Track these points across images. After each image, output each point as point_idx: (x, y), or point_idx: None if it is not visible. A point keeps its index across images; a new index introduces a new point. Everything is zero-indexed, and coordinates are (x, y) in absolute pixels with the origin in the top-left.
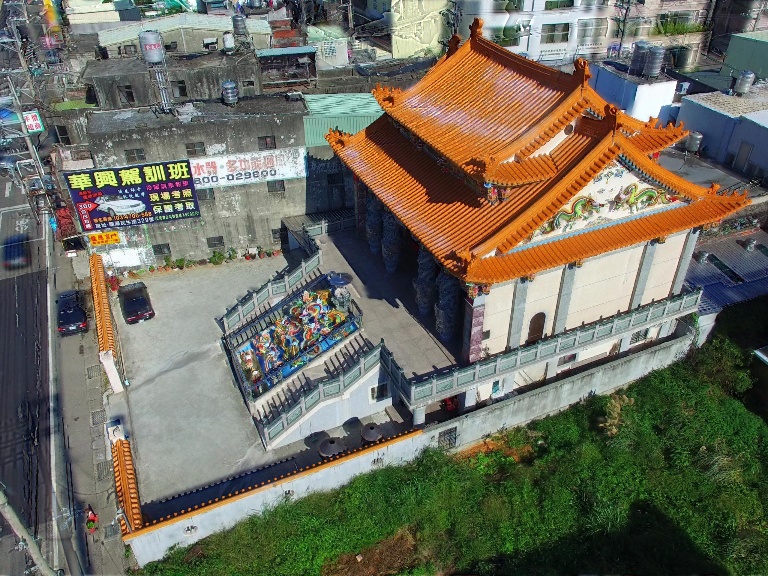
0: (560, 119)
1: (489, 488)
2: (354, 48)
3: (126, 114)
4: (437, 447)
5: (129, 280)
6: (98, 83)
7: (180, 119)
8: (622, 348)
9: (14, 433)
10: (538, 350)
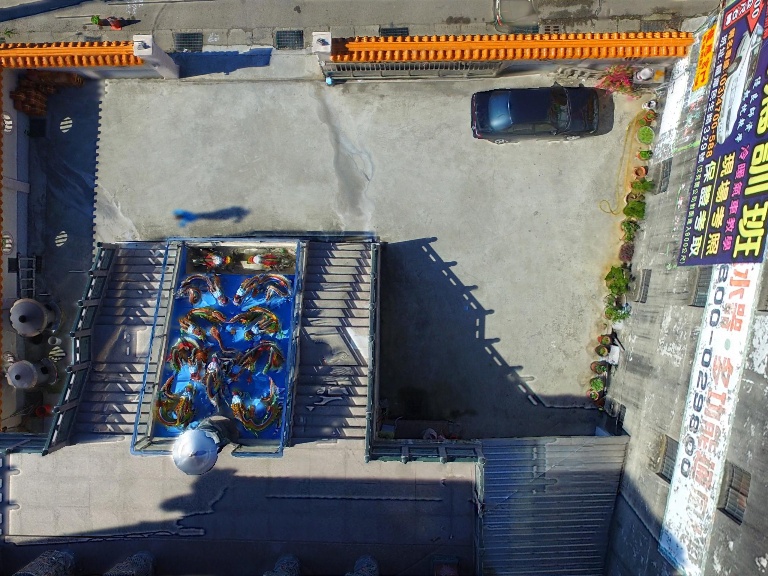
0: None
1: None
2: None
3: None
4: None
5: (633, 110)
6: None
7: None
8: None
9: None
10: None
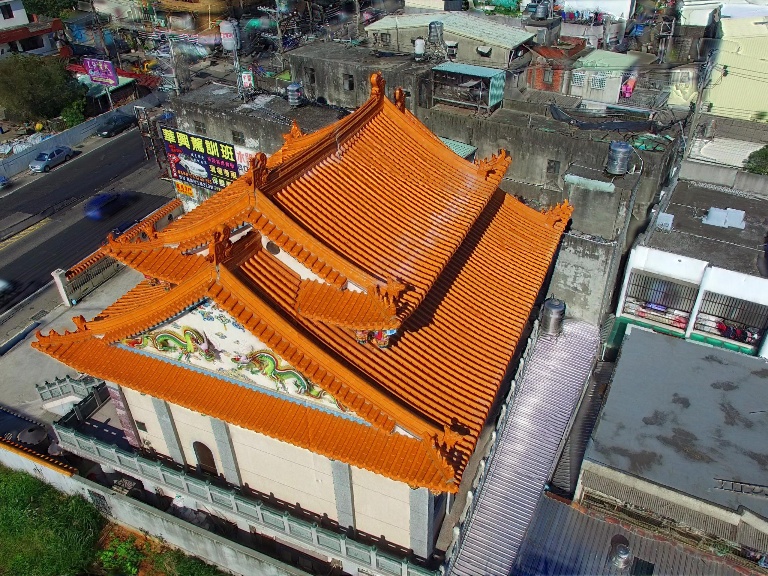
0: (225, 222)
1: (66, 572)
2: None
3: (225, 91)
4: (93, 502)
5: None
6: (292, 60)
7: (239, 107)
8: (345, 567)
9: (3, 296)
10: (182, 481)
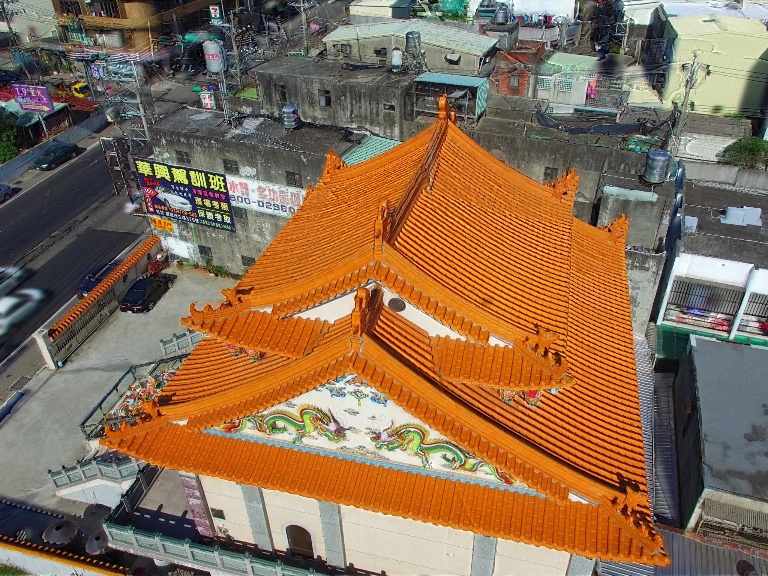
0: (338, 280)
1: None
2: (614, 87)
3: (204, 115)
4: None
5: (174, 269)
6: (260, 78)
7: (229, 133)
8: None
9: None
10: (278, 571)
